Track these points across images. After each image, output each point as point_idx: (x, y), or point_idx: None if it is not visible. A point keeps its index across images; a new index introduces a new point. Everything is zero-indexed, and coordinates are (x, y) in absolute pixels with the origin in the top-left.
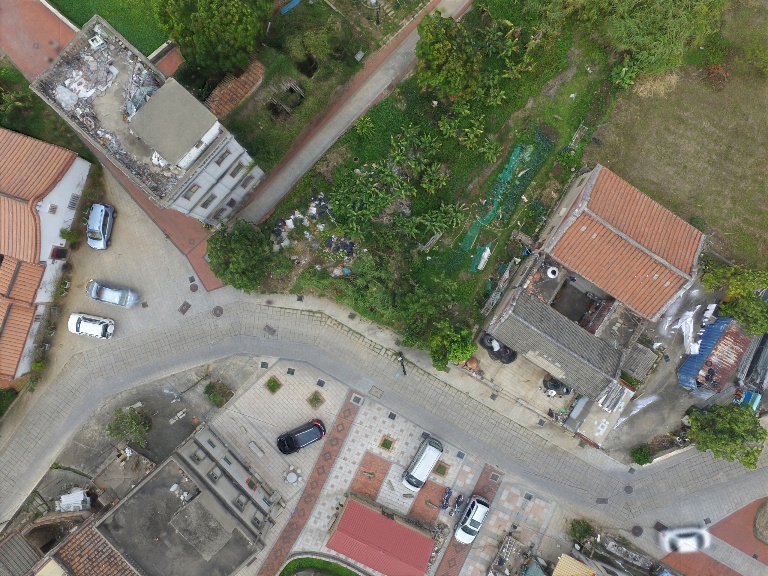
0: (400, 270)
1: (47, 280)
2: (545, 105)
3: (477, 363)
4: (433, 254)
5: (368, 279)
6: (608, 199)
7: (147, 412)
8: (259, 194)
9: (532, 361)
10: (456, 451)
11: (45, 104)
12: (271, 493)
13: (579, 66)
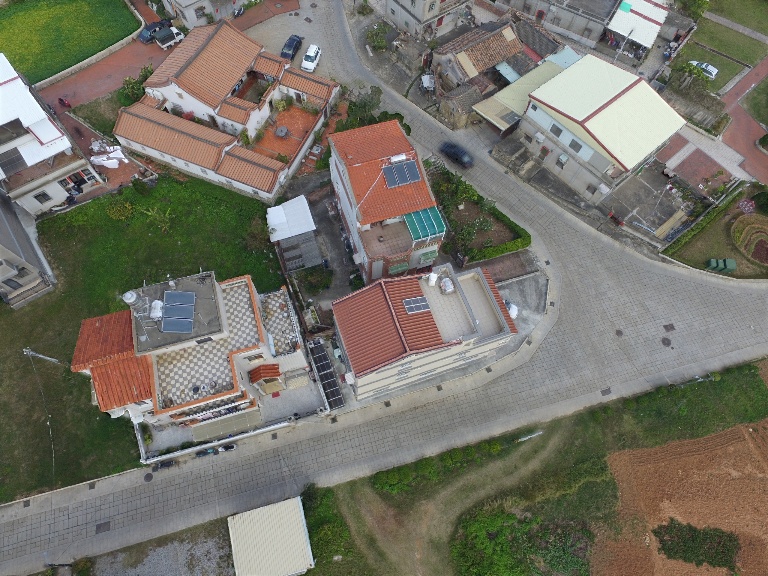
0: None
1: None
2: None
3: None
4: None
5: None
6: None
7: None
8: None
9: None
10: None
11: None
12: None
13: None
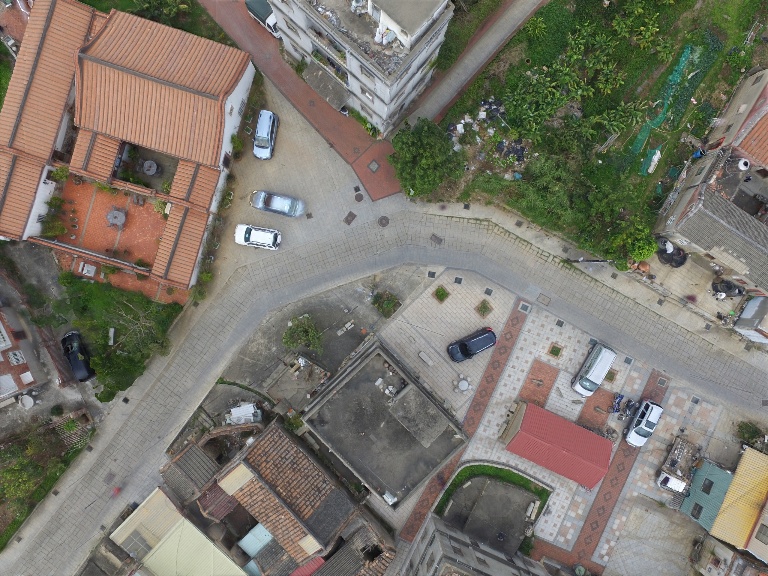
0: None
1: (219, 187)
2: (714, 5)
3: (649, 266)
4: (604, 157)
5: (547, 180)
6: None
7: (314, 324)
8: (424, 101)
9: (716, 257)
10: (624, 357)
11: (202, 11)
12: (442, 402)
13: None
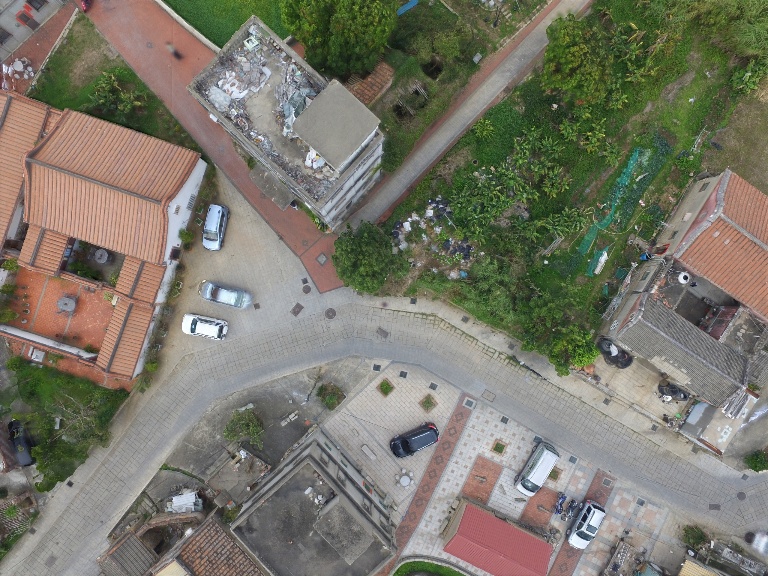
0: (518, 274)
1: (165, 281)
2: (663, 109)
3: (594, 368)
4: (550, 258)
5: (490, 283)
6: (739, 205)
7: (258, 414)
8: (373, 196)
9: (657, 366)
10: (568, 456)
11: (158, 104)
12: (383, 496)
13: (698, 70)
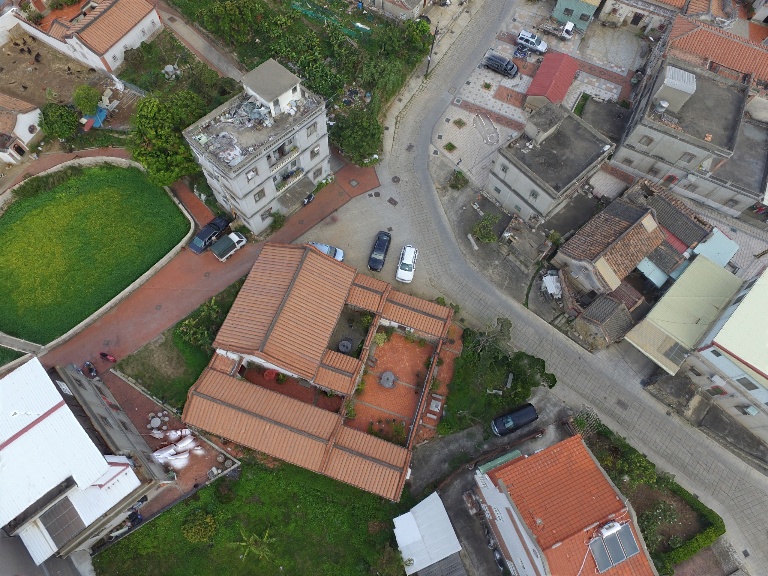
0: None
1: None
2: None
3: None
4: None
5: (375, 72)
6: None
7: None
8: None
9: None
10: None
11: None
12: None
13: None
